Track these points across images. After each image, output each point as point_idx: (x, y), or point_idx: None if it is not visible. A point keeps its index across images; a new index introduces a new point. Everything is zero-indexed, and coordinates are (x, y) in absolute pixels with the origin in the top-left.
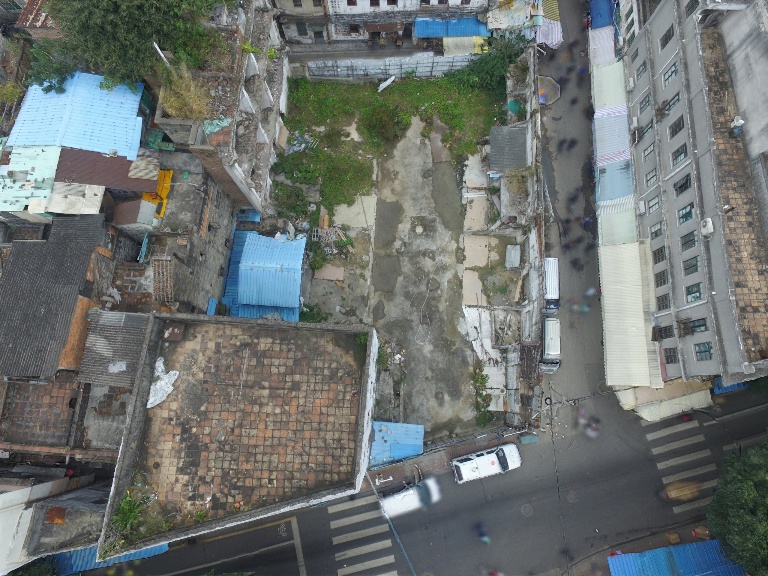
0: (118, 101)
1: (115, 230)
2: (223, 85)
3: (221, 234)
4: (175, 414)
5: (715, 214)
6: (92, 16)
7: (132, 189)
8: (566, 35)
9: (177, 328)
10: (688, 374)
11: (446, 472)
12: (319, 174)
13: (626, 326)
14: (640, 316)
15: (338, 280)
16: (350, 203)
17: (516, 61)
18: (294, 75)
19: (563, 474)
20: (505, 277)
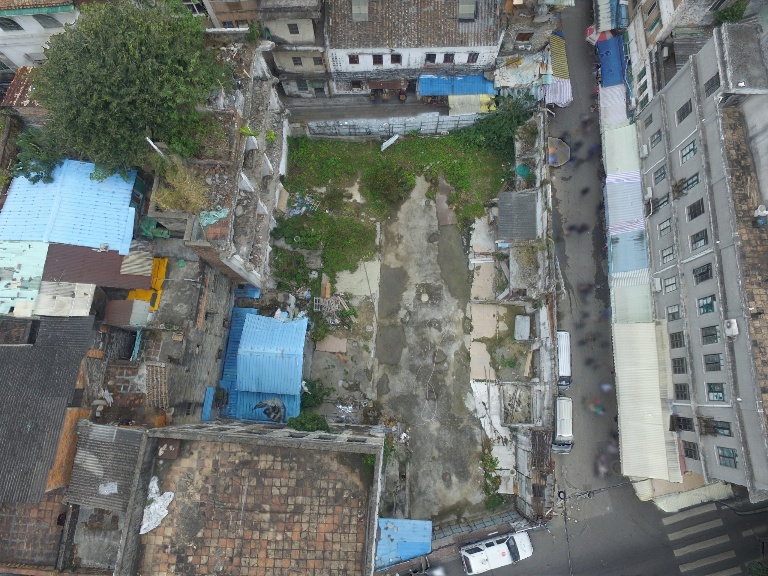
0: (109, 190)
1: (107, 327)
2: (220, 173)
3: (219, 317)
4: (170, 541)
5: (740, 315)
6: (80, 113)
7: (124, 287)
8: (575, 89)
9: (172, 445)
10: (710, 475)
11: (454, 559)
12: (320, 239)
13: (642, 412)
14: (657, 403)
15: (341, 352)
16: (353, 269)
17: (525, 123)
18: (294, 134)
19: (576, 562)
20: (514, 350)
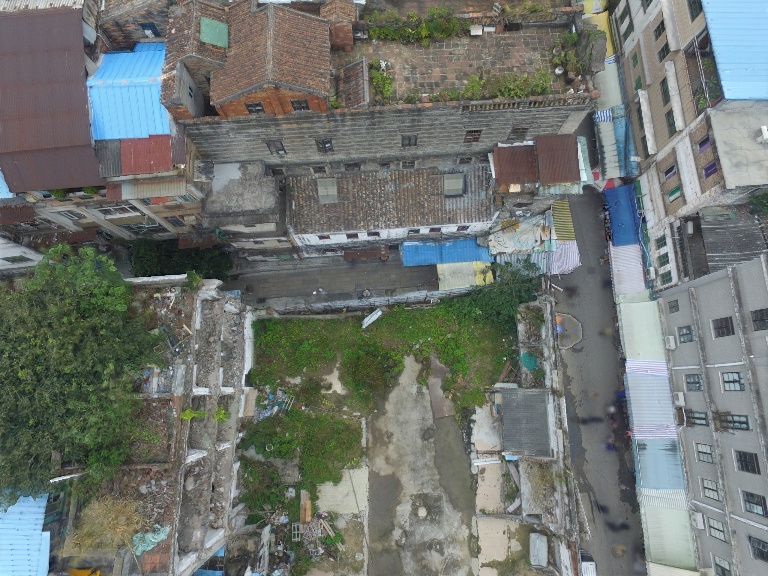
0: (16, 510)
1: None
2: (157, 479)
3: None
4: None
5: None
6: None
7: None
8: (580, 237)
9: None
10: None
11: None
12: (297, 444)
13: None
14: None
15: None
16: (336, 480)
17: (528, 304)
18: (260, 317)
19: None
20: None
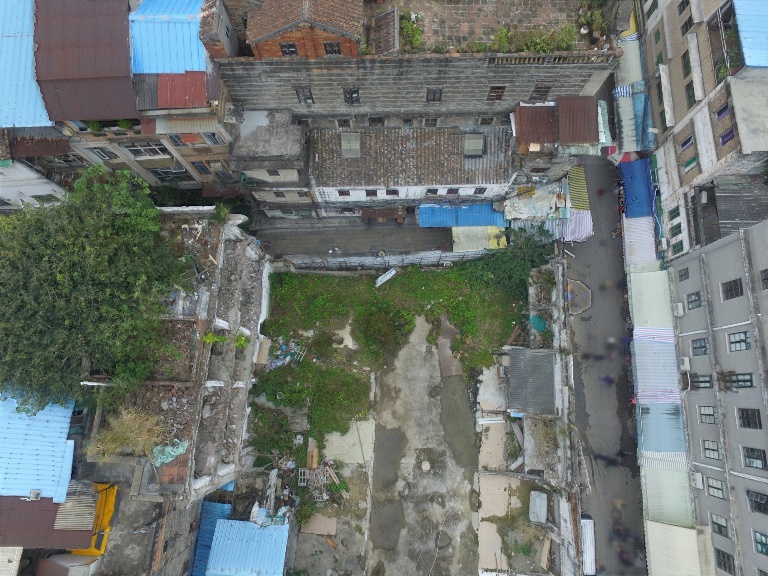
0: (43, 418)
1: None
2: (178, 396)
3: (183, 529)
4: None
5: None
6: None
7: (58, 547)
8: (594, 210)
9: None
10: None
11: None
12: (307, 394)
13: None
14: None
15: (329, 535)
16: (343, 431)
17: (540, 268)
18: (277, 270)
19: None
20: (529, 534)
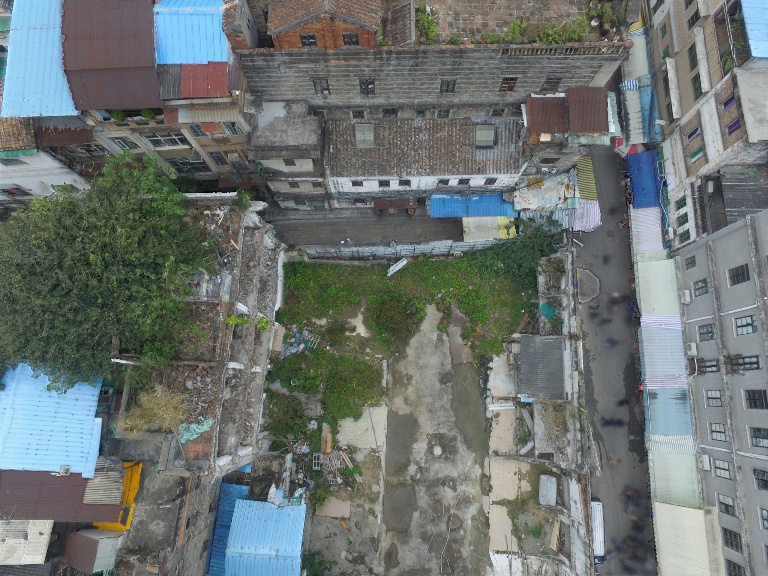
0: (72, 397)
1: None
2: (202, 375)
3: (204, 509)
4: None
5: None
6: None
7: (88, 520)
8: (601, 202)
9: None
10: None
11: None
12: (320, 381)
13: None
14: None
15: (343, 518)
16: (356, 417)
17: (549, 256)
18: (291, 259)
19: None
20: (539, 517)
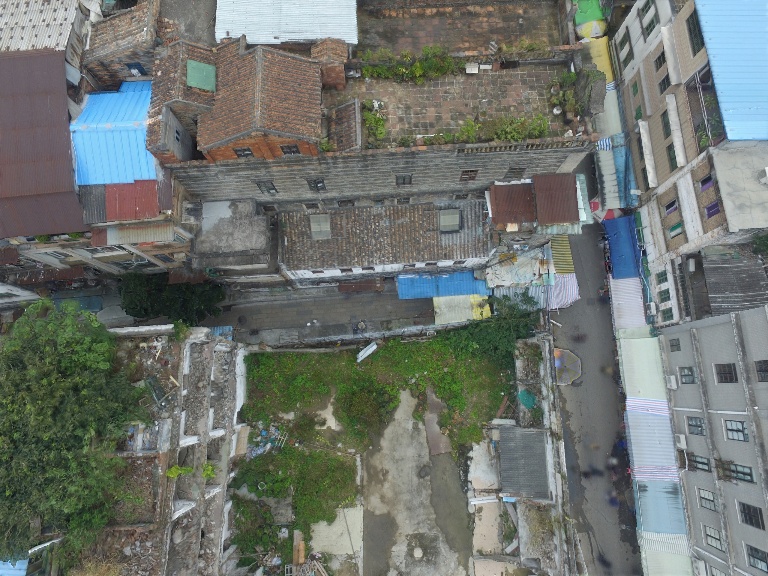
0: None
1: None
2: (141, 540)
3: None
4: None
5: None
6: None
7: None
8: (580, 267)
9: None
10: None
11: None
12: (290, 483)
13: None
14: None
15: None
16: (330, 520)
17: (526, 340)
18: (252, 351)
19: None
20: None
